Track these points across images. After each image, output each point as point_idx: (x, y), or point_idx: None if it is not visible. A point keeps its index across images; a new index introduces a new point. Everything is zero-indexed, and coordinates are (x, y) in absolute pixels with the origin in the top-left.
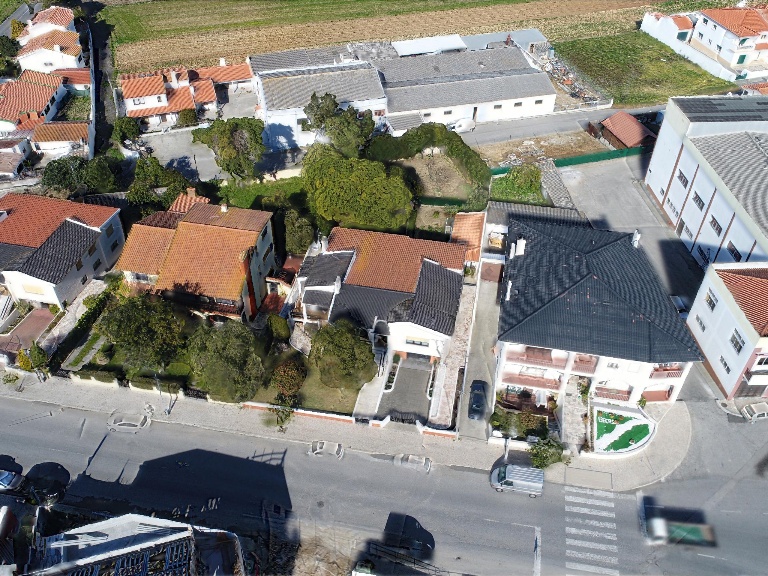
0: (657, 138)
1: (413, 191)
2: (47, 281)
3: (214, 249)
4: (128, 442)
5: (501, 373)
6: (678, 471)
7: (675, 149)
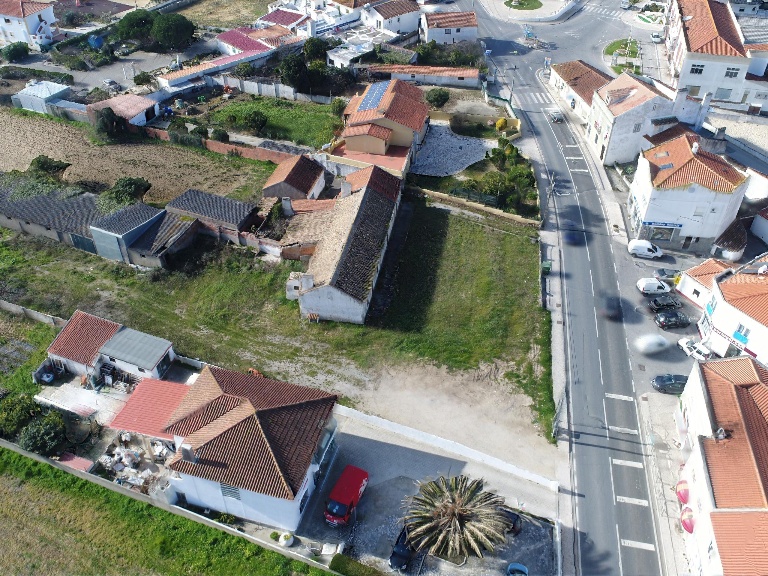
0: None
1: None
2: None
3: None
4: None
5: None
6: None
7: None
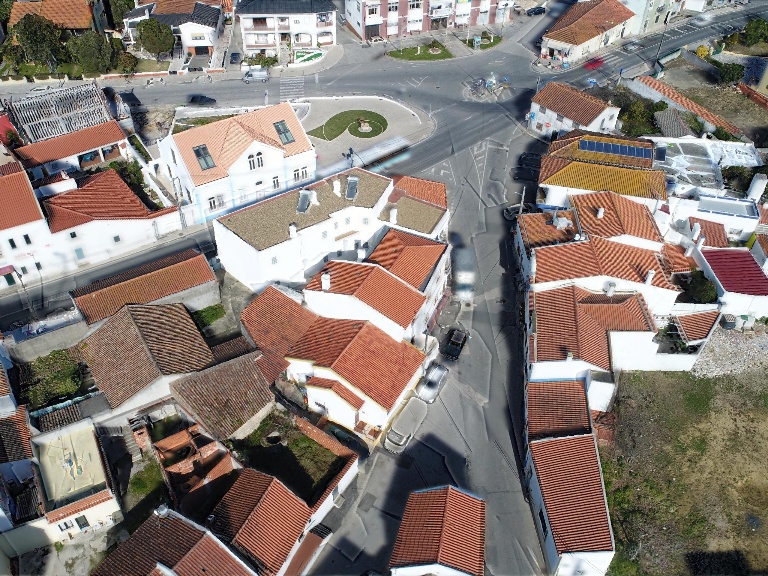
0: None
1: None
2: None
3: (69, 6)
4: None
5: (244, 41)
6: (336, 65)
7: None
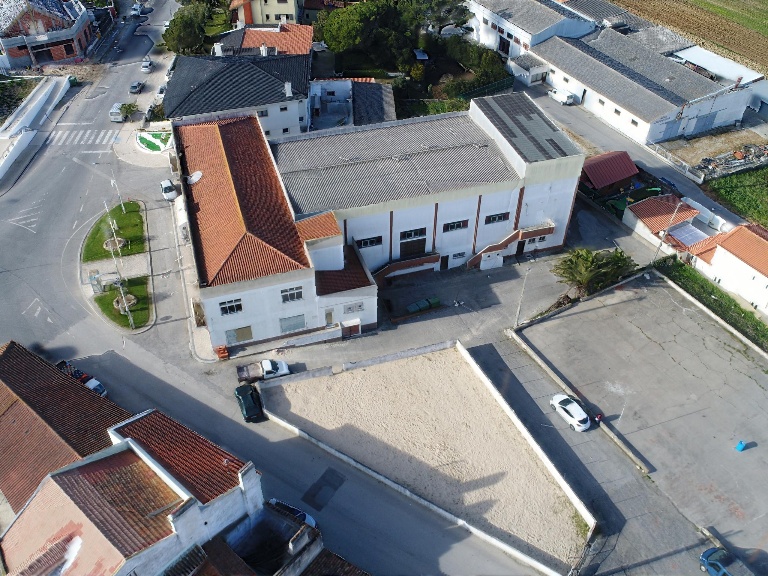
0: None
1: (406, 66)
2: None
3: None
4: (160, 30)
5: None
6: (125, 163)
7: None
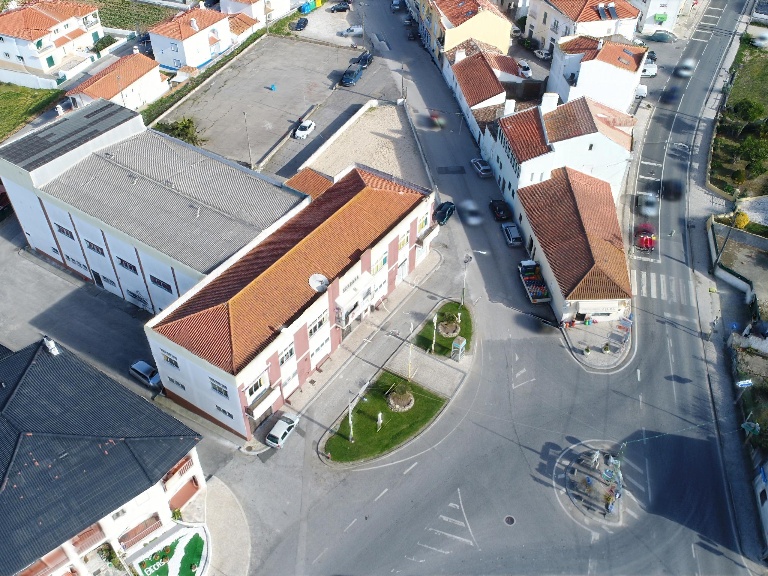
0: (9, 199)
1: None
2: None
3: None
4: None
5: None
6: (254, 557)
7: (35, 205)
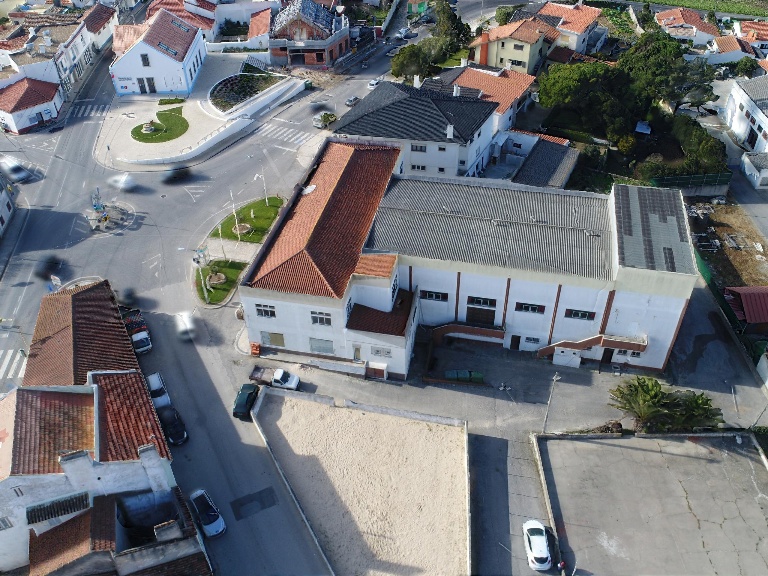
0: None
1: (615, 136)
2: (512, 20)
3: None
4: None
5: None
6: None
7: None
